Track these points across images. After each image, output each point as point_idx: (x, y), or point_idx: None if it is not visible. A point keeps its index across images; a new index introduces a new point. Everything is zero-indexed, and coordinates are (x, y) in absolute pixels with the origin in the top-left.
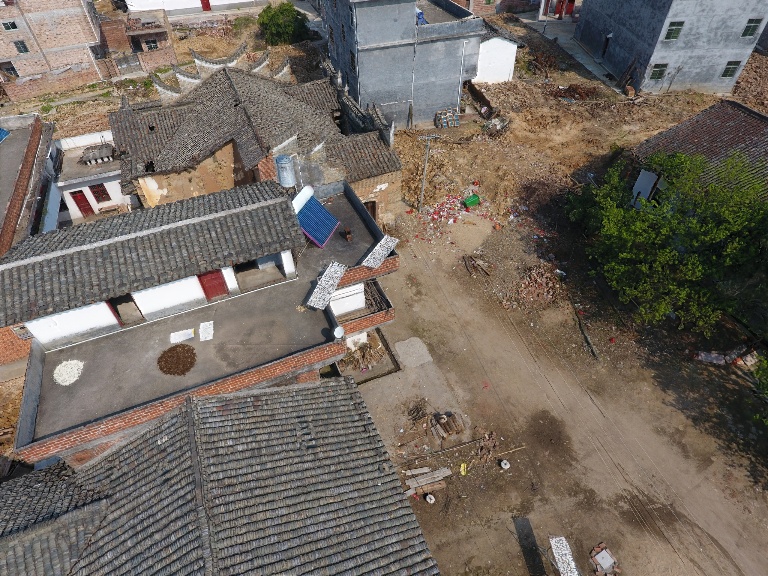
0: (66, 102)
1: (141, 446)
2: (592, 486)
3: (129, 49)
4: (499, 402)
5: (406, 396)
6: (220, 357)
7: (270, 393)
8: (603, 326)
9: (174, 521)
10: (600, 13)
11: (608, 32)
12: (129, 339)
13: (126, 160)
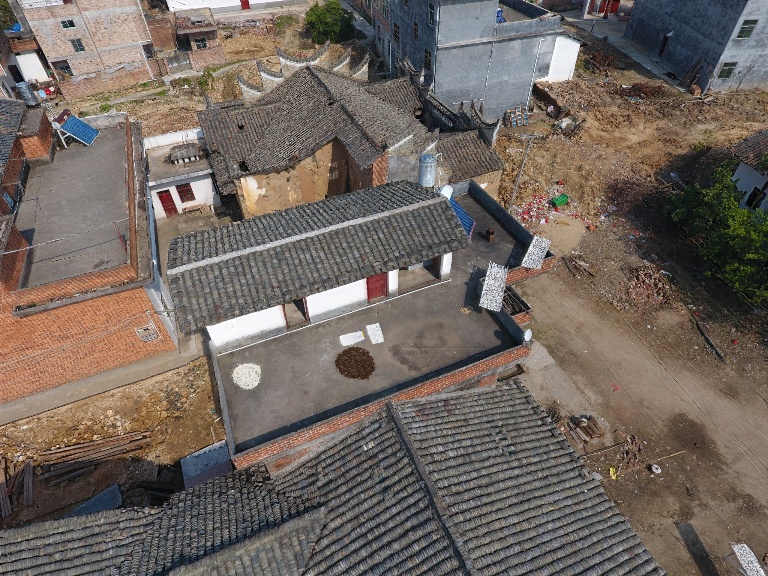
0: (122, 101)
1: (344, 452)
2: (749, 491)
3: (174, 48)
4: (633, 405)
5: (536, 399)
6: (399, 360)
7: (455, 397)
8: (722, 328)
9: (413, 530)
10: (657, 11)
11: (668, 31)
12: (298, 342)
13: (218, 159)
